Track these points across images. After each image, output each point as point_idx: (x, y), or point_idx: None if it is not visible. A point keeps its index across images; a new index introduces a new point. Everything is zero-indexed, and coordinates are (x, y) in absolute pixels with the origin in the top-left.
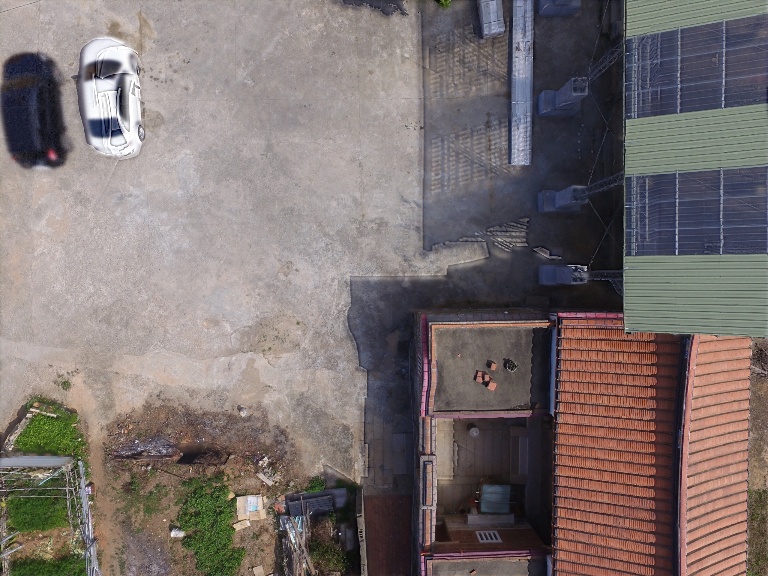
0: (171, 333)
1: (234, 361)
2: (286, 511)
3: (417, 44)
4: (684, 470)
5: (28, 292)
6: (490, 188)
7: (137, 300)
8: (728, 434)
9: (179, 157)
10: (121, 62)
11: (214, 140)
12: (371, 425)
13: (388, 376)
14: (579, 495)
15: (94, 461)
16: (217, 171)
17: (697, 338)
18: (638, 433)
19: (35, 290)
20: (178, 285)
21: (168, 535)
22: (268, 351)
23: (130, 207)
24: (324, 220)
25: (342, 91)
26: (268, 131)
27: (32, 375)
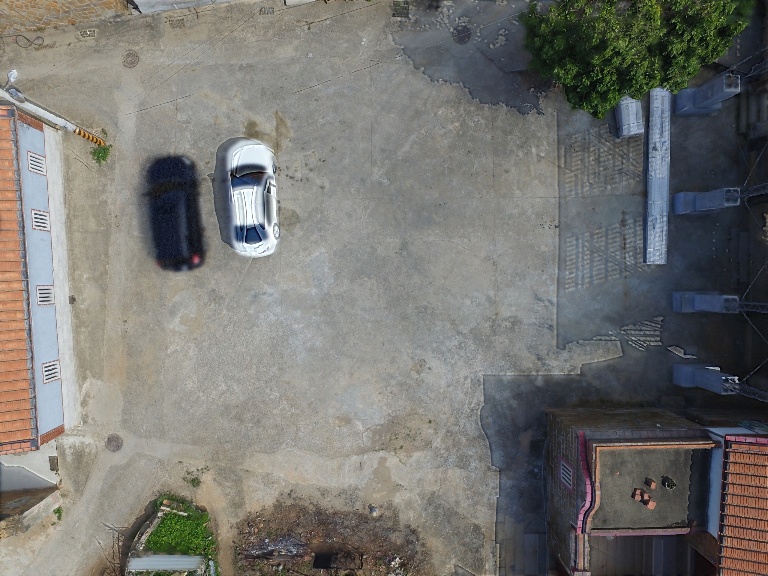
0: (303, 431)
1: (366, 460)
2: None
3: (552, 143)
4: None
5: (160, 389)
6: (624, 287)
7: (269, 397)
8: None
9: (314, 255)
10: (257, 161)
11: (349, 238)
12: (503, 525)
13: (520, 475)
14: None
15: (224, 560)
16: (351, 269)
17: None
18: None
19: (167, 387)
20: (310, 383)
21: None
22: (400, 449)
23: (264, 305)
24: (458, 318)
25: (477, 190)
26: (403, 229)
27: (161, 471)
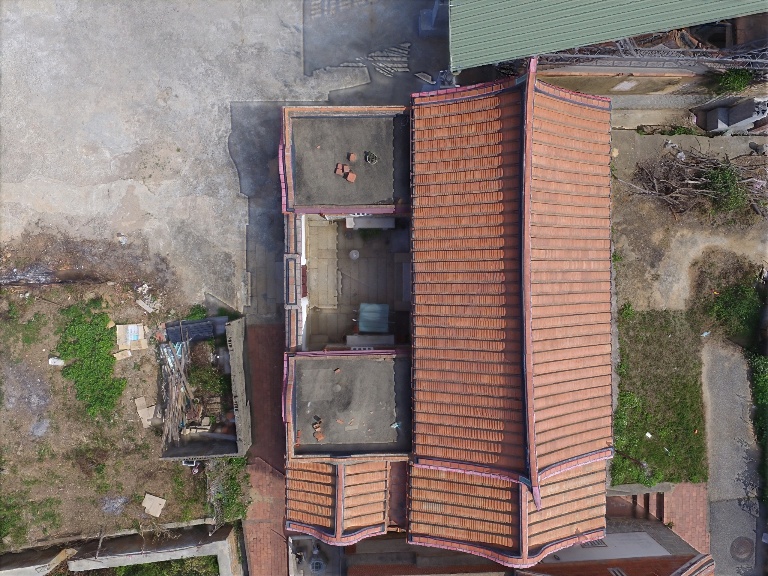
0: (50, 160)
1: (114, 188)
2: (167, 340)
3: None
4: (526, 230)
5: None
6: (370, 13)
7: (15, 127)
8: (586, 218)
9: None
10: None
11: None
12: (253, 253)
13: (270, 203)
14: (435, 278)
15: None
16: None
17: (531, 87)
18: (488, 205)
19: None
20: (56, 111)
21: (47, 365)
22: (148, 178)
23: (7, 32)
24: (203, 45)
25: None
26: None
27: None
